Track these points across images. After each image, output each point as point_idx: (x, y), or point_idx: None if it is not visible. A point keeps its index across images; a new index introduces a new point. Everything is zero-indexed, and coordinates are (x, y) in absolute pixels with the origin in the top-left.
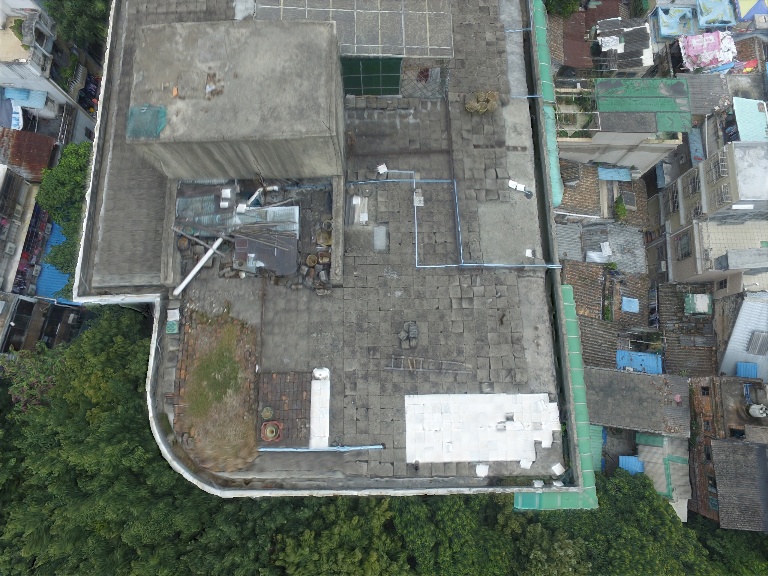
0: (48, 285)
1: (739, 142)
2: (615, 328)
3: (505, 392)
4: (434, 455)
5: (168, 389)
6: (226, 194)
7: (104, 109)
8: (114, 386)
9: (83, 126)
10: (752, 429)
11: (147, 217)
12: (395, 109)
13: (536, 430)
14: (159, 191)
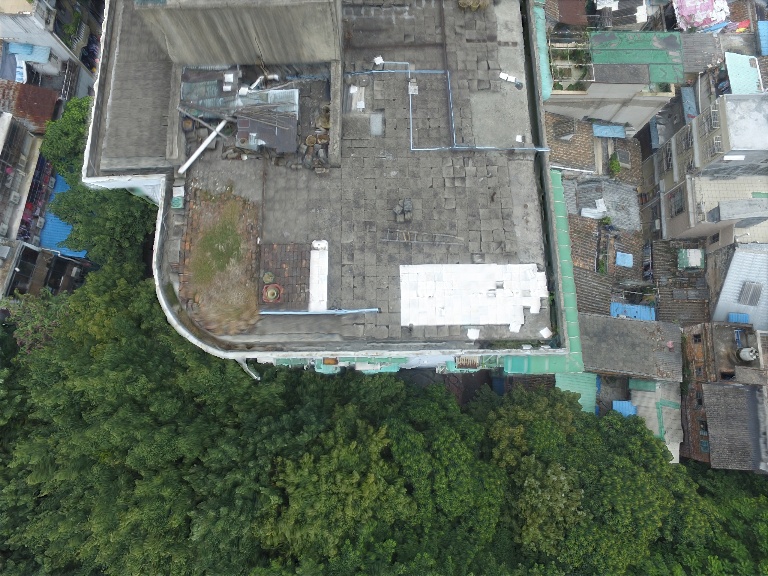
0: (52, 238)
1: (731, 94)
2: (609, 281)
3: (495, 262)
4: (427, 319)
5: (174, 259)
6: (229, 78)
7: (111, 8)
8: (118, 322)
9: (86, 84)
10: (742, 370)
11: (153, 105)
12: (391, 6)
13: (525, 296)
14: (164, 81)
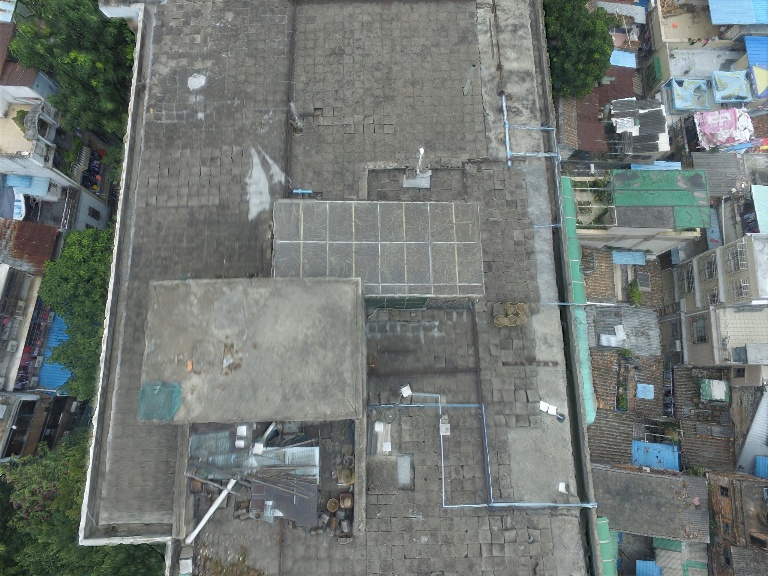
0: (50, 375)
1: (759, 235)
2: (630, 418)
3: None
4: None
5: None
6: (242, 432)
7: (112, 316)
8: None
9: (86, 206)
10: None
11: (157, 446)
12: (419, 321)
13: None
14: None
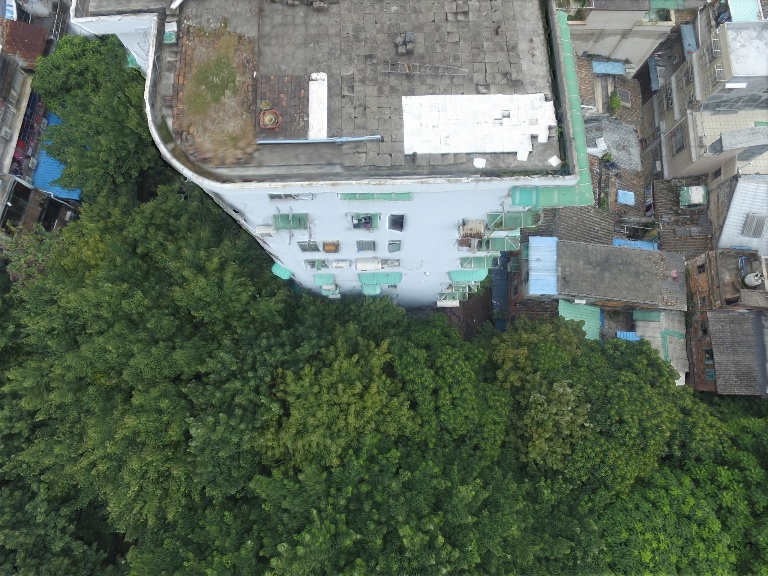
0: (44, 179)
1: (731, 22)
2: (611, 217)
3: (501, 92)
4: (432, 147)
5: (167, 92)
6: None
7: None
8: (112, 245)
9: (77, 28)
10: (748, 293)
11: None
12: None
13: (532, 125)
14: None
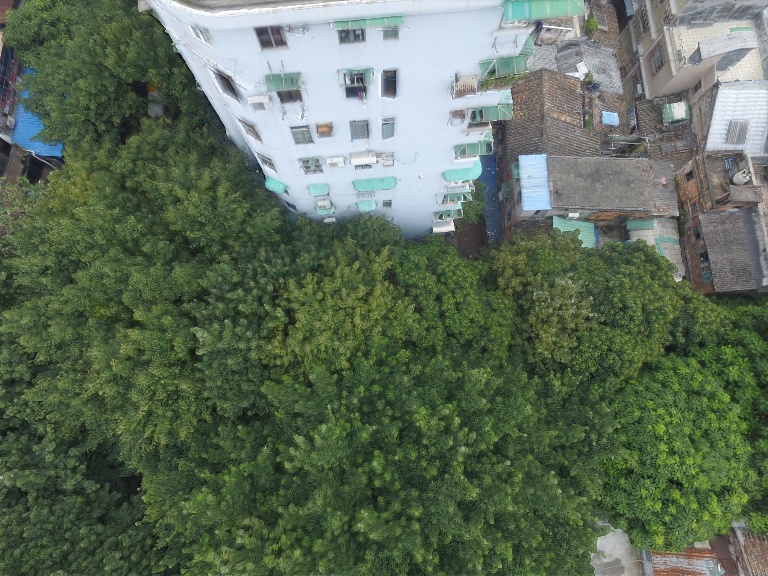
0: (24, 139)
1: None
2: (597, 137)
3: None
4: None
5: None
6: None
7: None
8: (100, 179)
9: None
10: (737, 189)
11: None
12: None
13: None
14: None
